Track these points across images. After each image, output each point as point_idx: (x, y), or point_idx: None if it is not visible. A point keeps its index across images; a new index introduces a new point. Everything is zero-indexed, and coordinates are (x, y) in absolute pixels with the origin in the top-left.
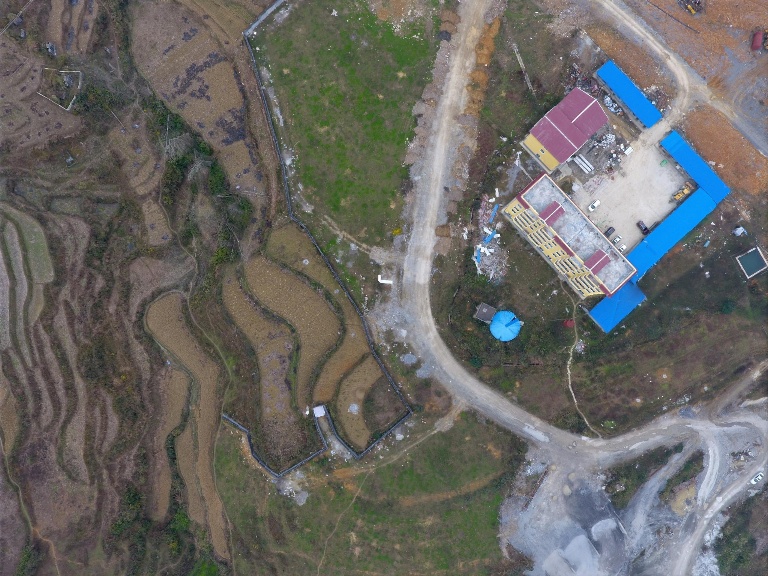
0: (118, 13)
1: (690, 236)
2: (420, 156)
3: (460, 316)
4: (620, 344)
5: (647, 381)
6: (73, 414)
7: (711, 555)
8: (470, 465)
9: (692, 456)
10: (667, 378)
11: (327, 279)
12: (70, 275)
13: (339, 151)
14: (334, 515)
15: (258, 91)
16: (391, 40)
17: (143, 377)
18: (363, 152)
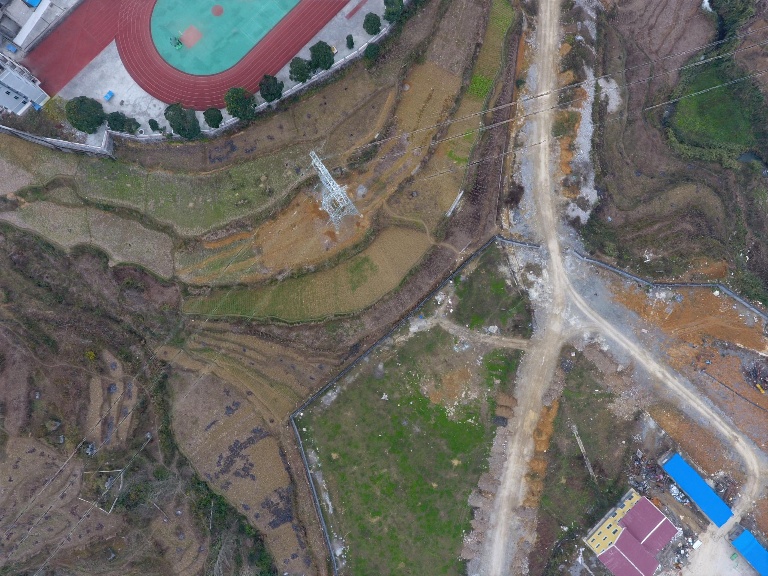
0: (158, 395)
1: None
2: (478, 552)
3: None
4: None
5: None
6: None
7: None
8: None
9: None
10: None
11: None
12: None
13: (392, 543)
14: None
15: (306, 476)
16: (445, 425)
17: None
18: (417, 545)
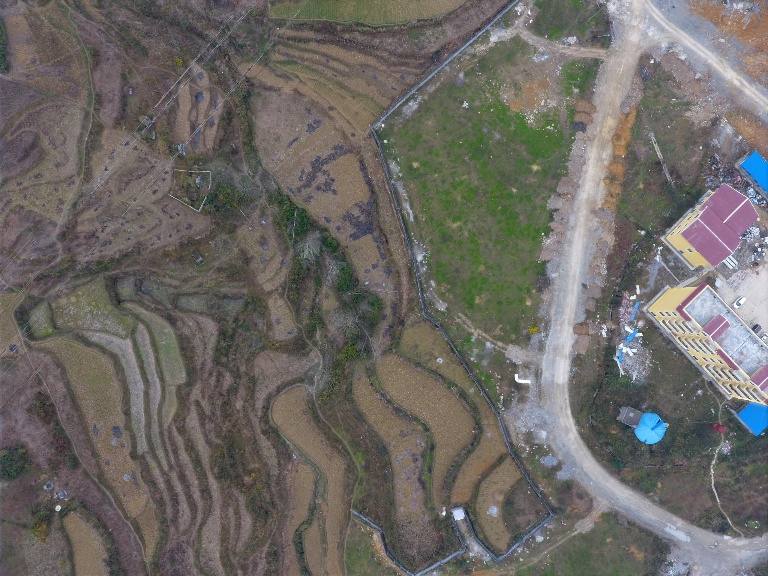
0: (243, 107)
1: None
2: (557, 252)
3: (603, 418)
4: (767, 445)
5: None
6: (208, 516)
7: None
8: (612, 567)
9: None
10: None
11: (462, 378)
12: (200, 375)
13: (472, 247)
14: None
15: (387, 185)
16: (524, 132)
17: (271, 473)
18: (497, 248)
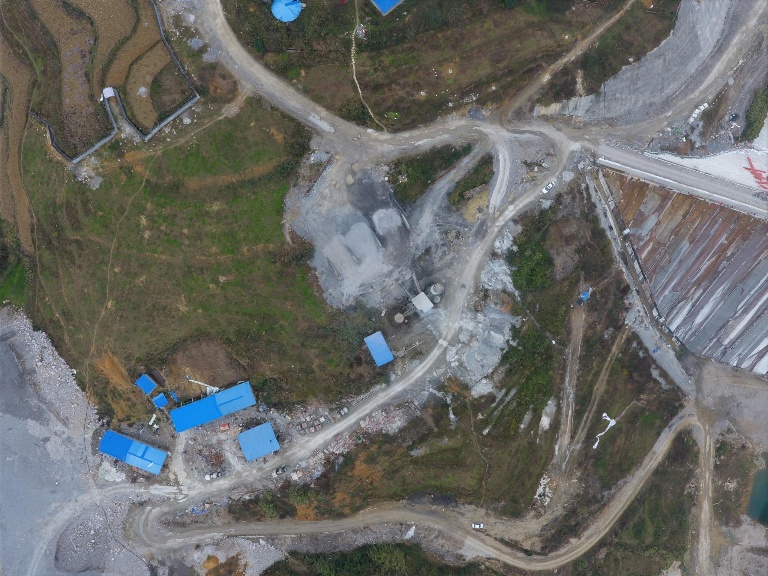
0: None
1: None
2: None
3: None
4: (400, 29)
5: (432, 75)
6: None
7: (502, 264)
8: (254, 150)
9: (481, 159)
10: (453, 73)
11: None
12: None
13: None
14: (125, 198)
15: None
16: None
17: None
18: None
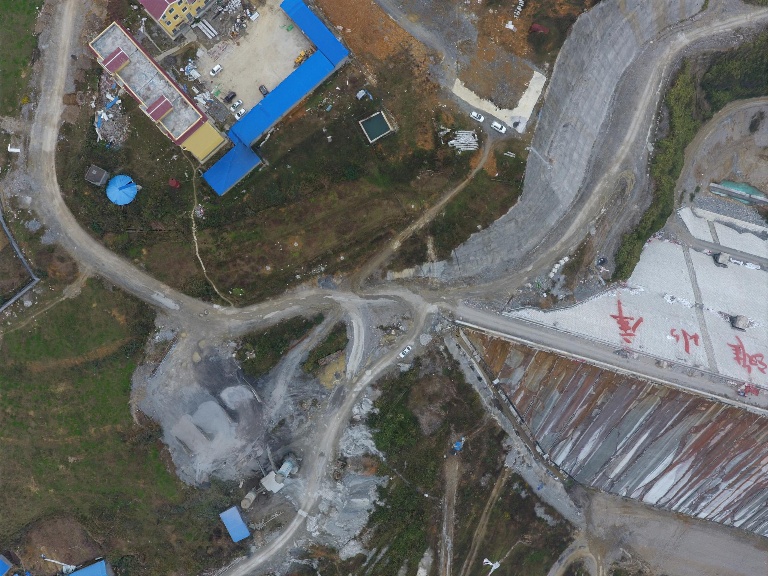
0: None
1: (313, 101)
2: (48, 24)
3: (78, 181)
4: (239, 208)
5: (278, 249)
6: None
7: (363, 429)
8: (97, 331)
9: (334, 327)
10: (298, 246)
11: None
12: None
13: None
14: None
15: None
16: None
17: None
18: None
